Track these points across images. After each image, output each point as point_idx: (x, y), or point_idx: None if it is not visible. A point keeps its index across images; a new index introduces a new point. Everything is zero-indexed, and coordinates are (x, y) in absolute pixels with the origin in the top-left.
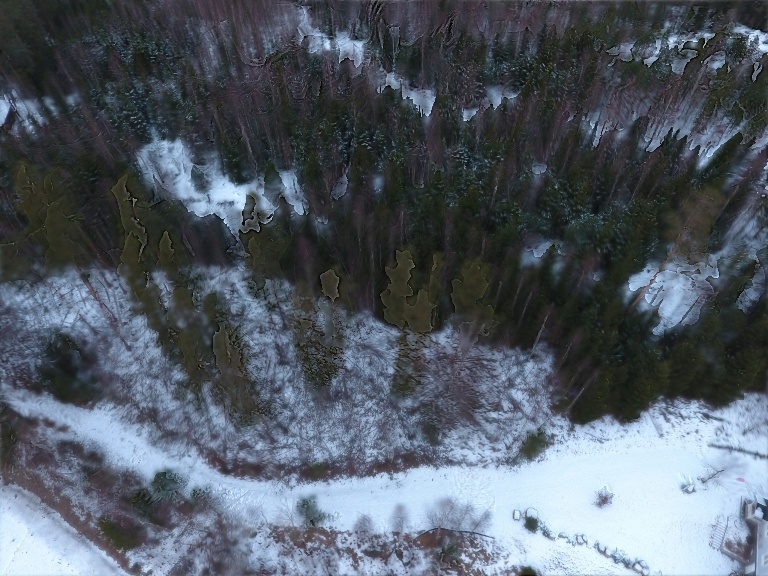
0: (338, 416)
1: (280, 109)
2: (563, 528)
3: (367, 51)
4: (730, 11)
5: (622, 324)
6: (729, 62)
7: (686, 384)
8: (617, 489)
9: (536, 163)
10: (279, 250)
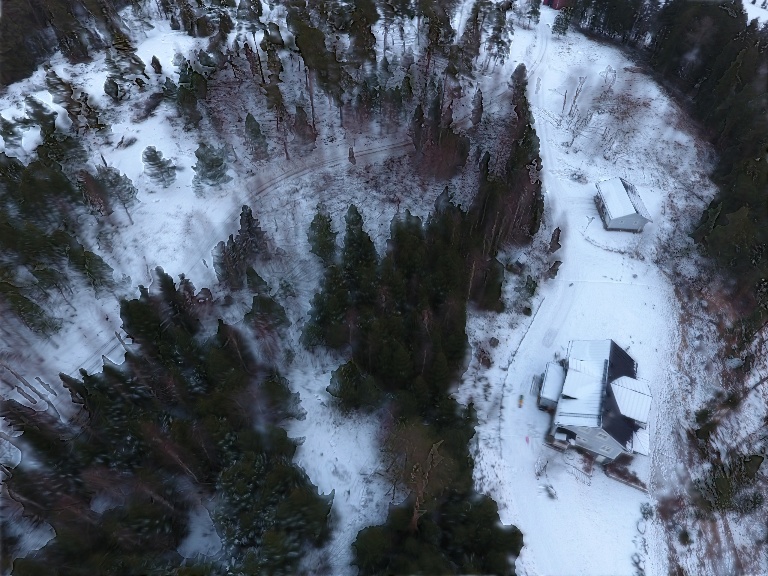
0: None
1: None
2: None
3: None
4: None
5: None
6: None
7: None
8: (574, 572)
9: None
10: None
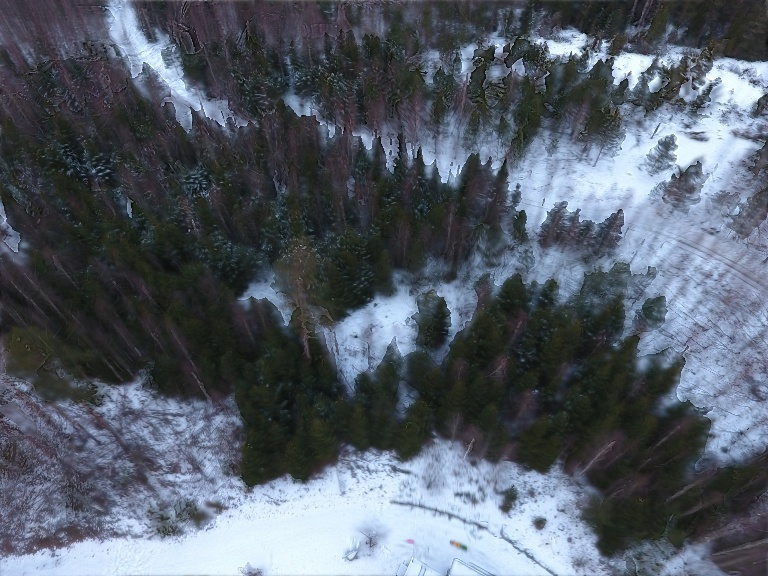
0: (1, 486)
1: (5, 129)
2: None
3: (166, 58)
4: (556, 14)
5: (297, 374)
6: (526, 70)
7: (363, 438)
8: (278, 559)
9: None
10: None
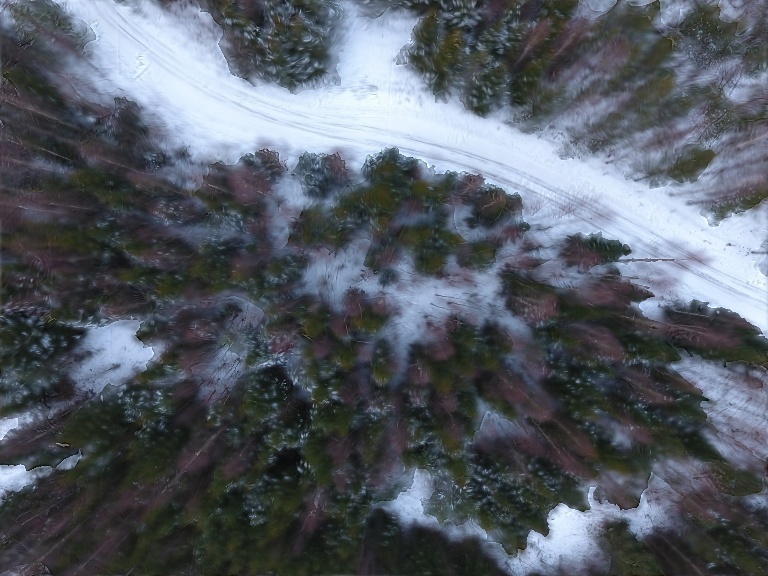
0: None
1: None
2: None
3: None
4: None
5: None
6: None
7: None
8: None
9: (416, 276)
10: None
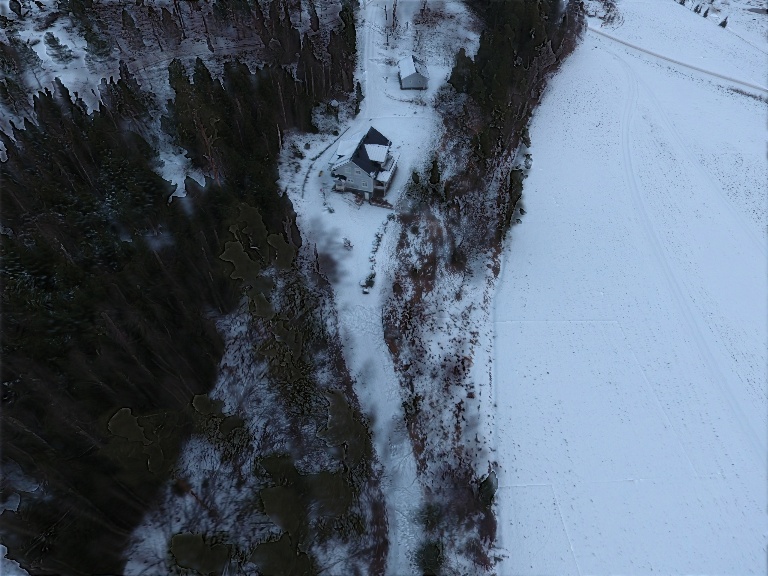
0: (314, 428)
1: None
2: (367, 268)
3: None
4: None
5: None
6: None
7: None
8: (338, 240)
9: None
10: (177, 415)
